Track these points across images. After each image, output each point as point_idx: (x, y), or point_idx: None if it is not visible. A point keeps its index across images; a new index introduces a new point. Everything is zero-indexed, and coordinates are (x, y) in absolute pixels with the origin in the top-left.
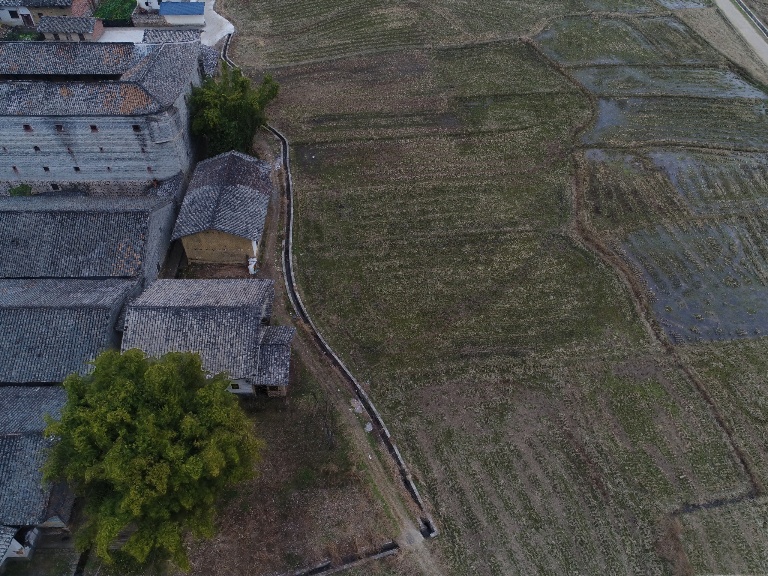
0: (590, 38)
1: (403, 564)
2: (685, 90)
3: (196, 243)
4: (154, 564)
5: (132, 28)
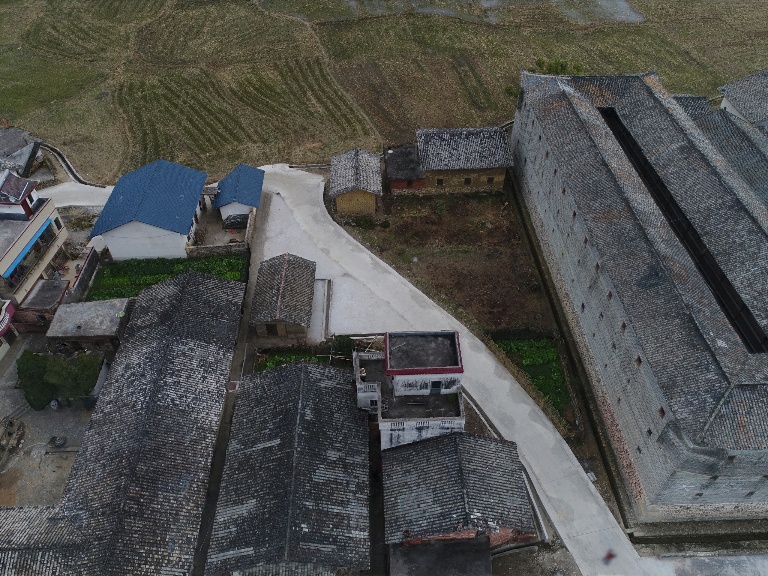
0: (309, 3)
1: None
2: None
3: None
4: None
5: (255, 254)
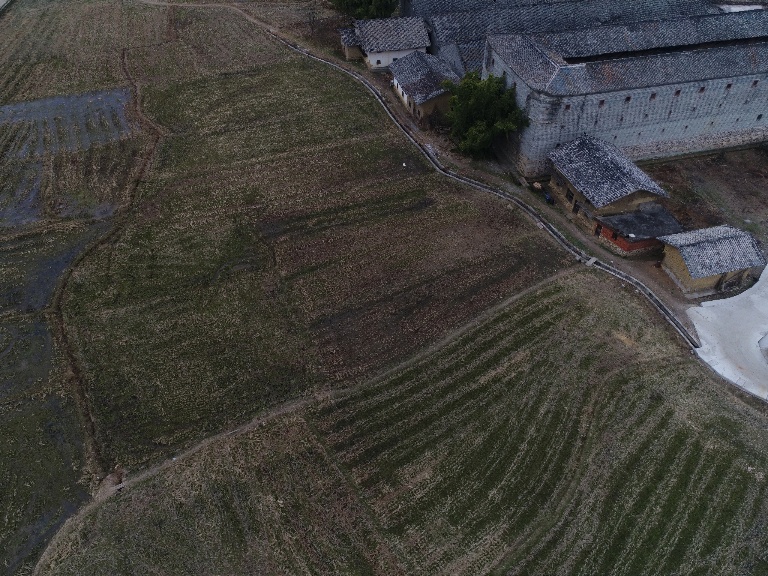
0: None
1: None
2: None
3: None
4: None
5: None
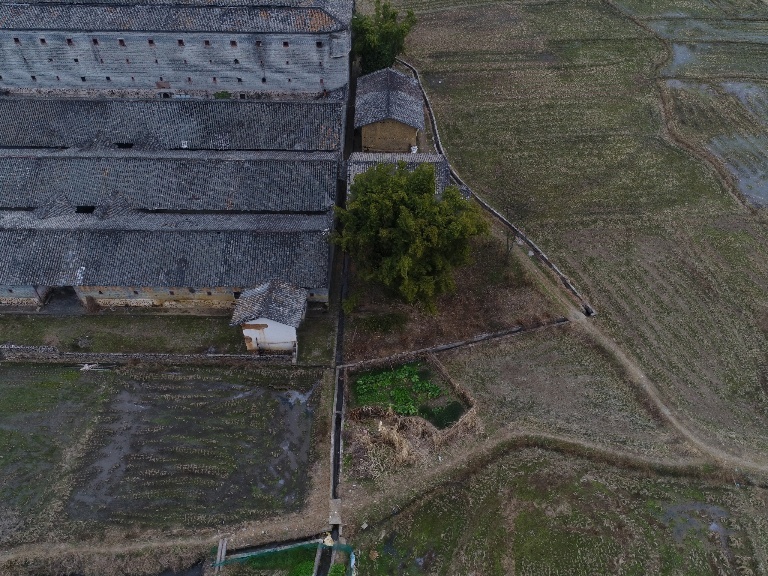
0: None
1: (574, 330)
2: (746, 38)
3: (372, 132)
4: (396, 324)
5: None
